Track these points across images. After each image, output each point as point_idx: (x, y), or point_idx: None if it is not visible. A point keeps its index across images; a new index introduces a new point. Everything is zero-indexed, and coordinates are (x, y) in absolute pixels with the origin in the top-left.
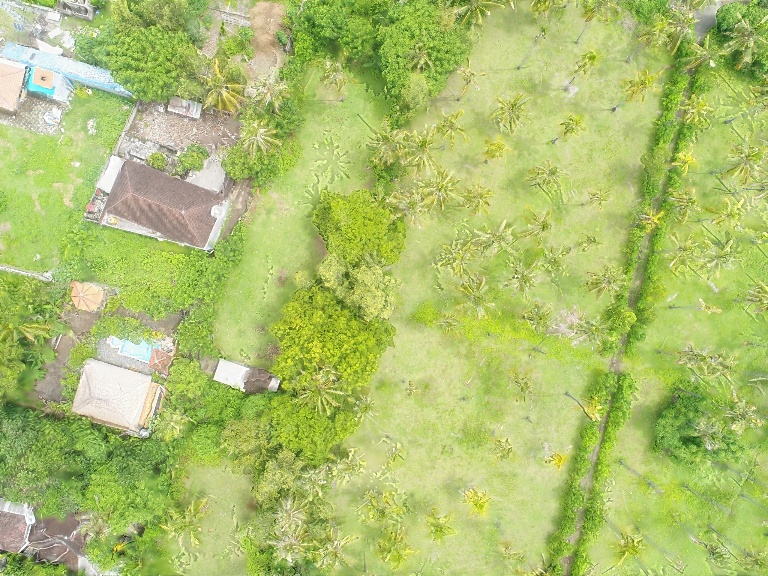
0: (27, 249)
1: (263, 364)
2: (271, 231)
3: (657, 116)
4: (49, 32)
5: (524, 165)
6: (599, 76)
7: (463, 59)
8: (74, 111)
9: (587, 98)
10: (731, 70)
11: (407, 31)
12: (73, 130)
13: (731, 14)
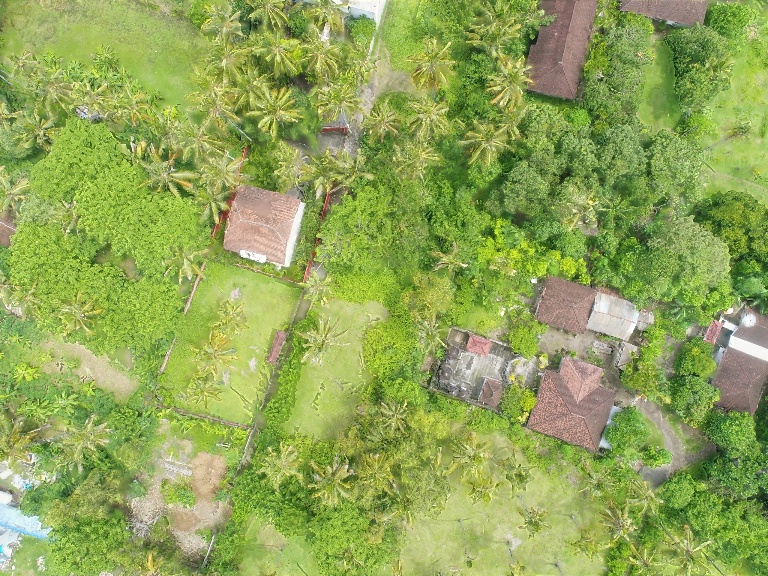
0: None
1: None
2: None
3: (602, 573)
4: (0, 473)
5: None
6: (543, 530)
7: (393, 560)
8: (24, 550)
9: (530, 551)
10: (681, 529)
11: (336, 538)
12: (23, 567)
13: (676, 500)
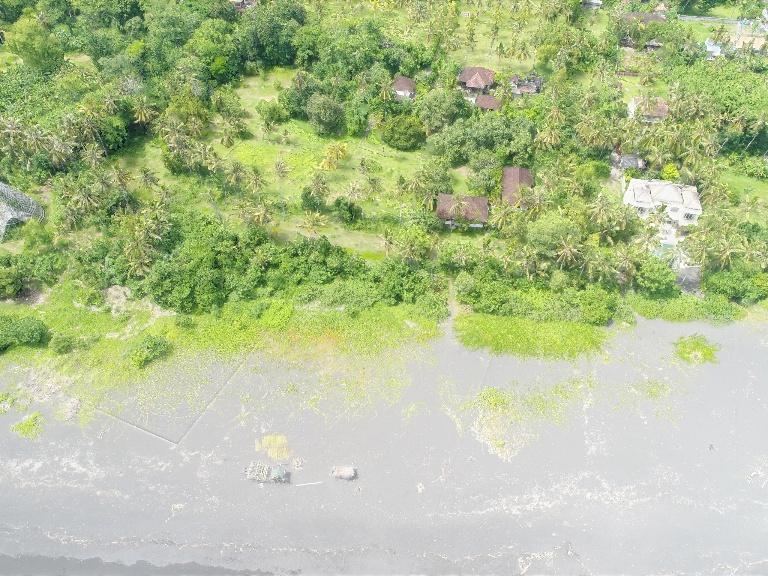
0: (692, 23)
1: (585, 6)
2: (598, 28)
3: None
4: None
5: (502, 39)
6: None
7: None
8: None
9: None
10: None
11: None
12: None
13: None
